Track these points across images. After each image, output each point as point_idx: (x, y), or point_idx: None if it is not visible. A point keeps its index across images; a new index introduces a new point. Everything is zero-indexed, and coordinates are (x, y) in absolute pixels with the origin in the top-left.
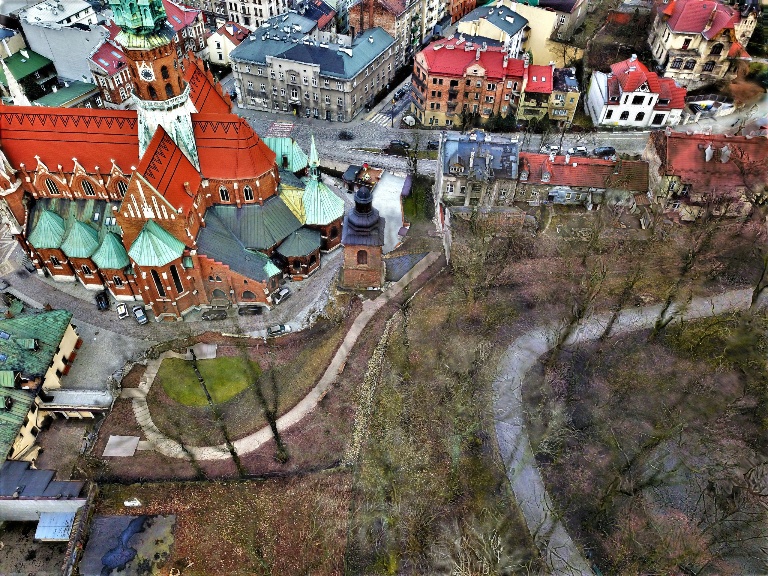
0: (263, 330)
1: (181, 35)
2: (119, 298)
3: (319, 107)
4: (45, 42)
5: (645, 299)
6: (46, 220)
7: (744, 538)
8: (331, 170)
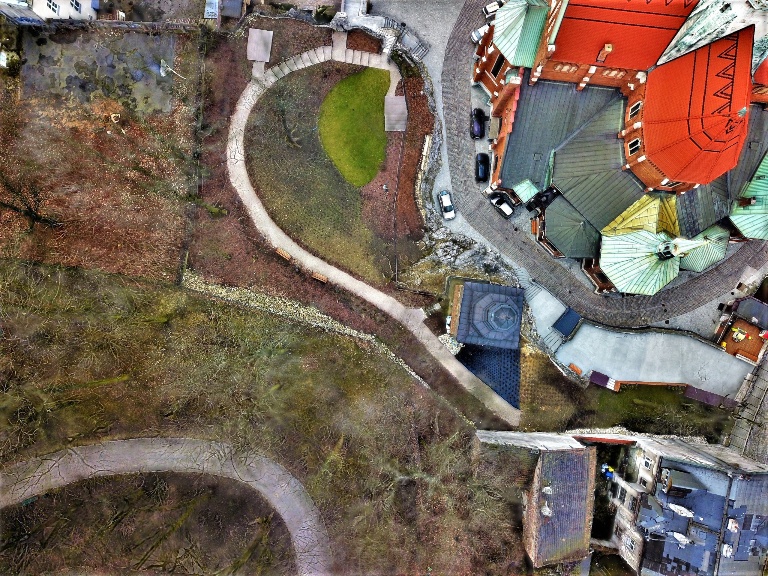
0: (451, 185)
1: None
2: None
3: None
4: None
5: None
6: None
7: None
8: None
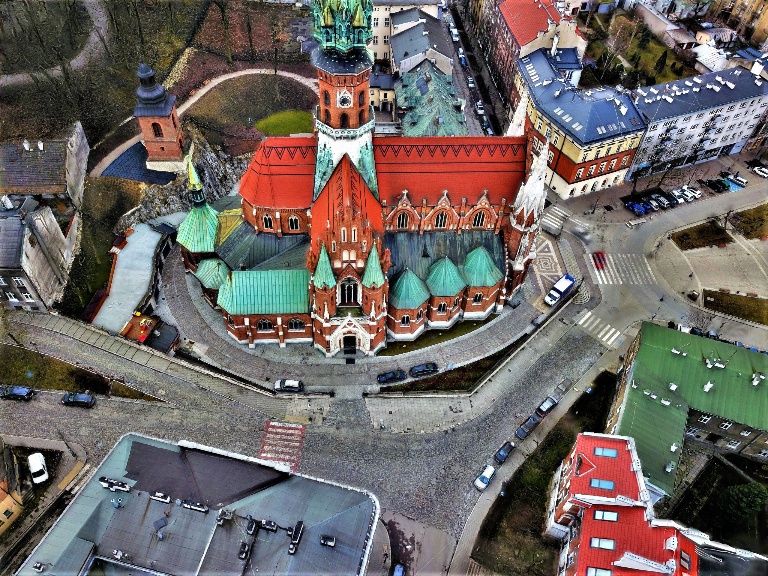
0: None
1: None
2: None
3: None
4: None
5: None
6: None
7: None
8: None
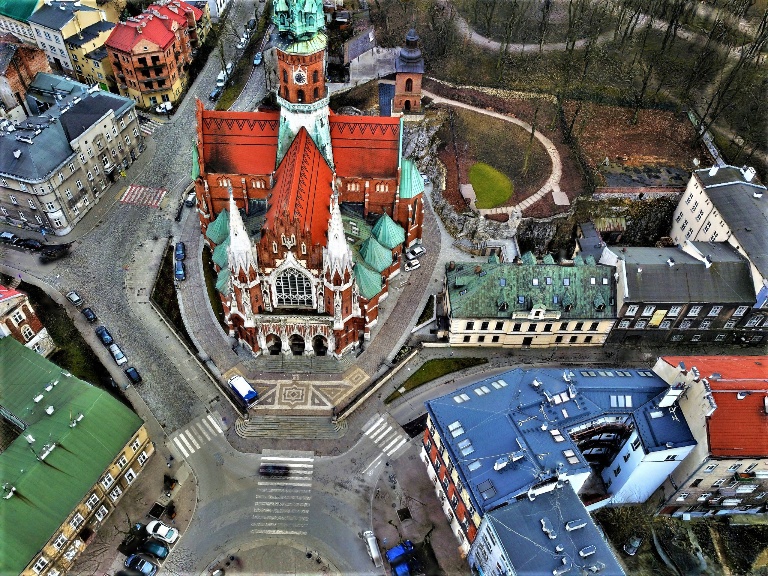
0: None
1: None
2: None
3: (125, 154)
4: None
5: (437, 8)
6: (363, 267)
7: (562, 7)
8: None
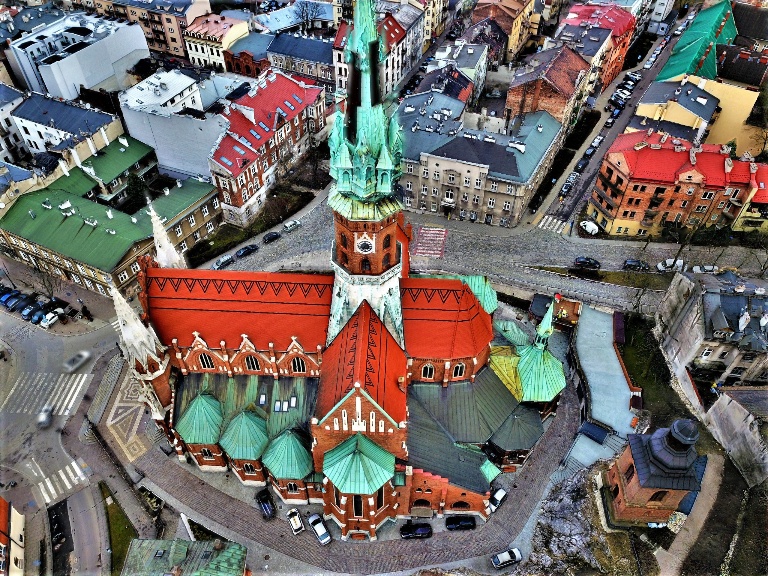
0: (484, 555)
1: (301, 116)
2: (288, 501)
3: (478, 210)
4: (148, 128)
5: None
6: (202, 408)
7: None
8: (507, 296)
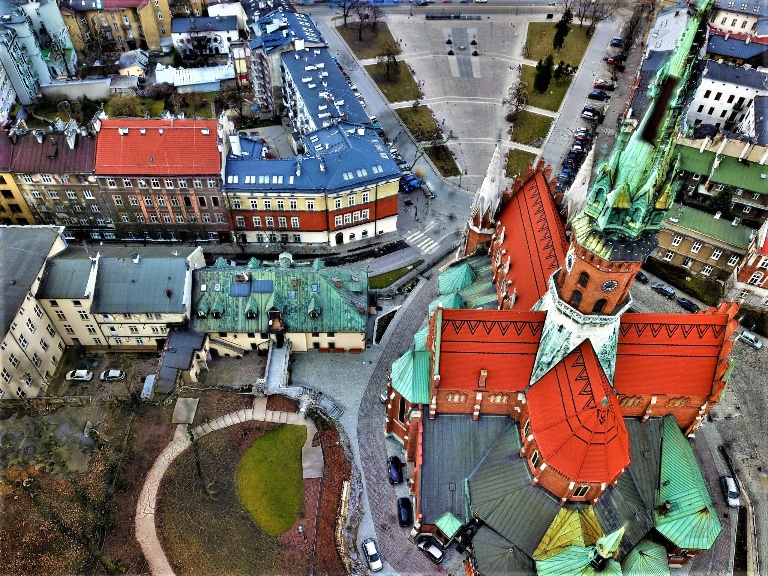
0: (375, 533)
1: None
2: None
3: None
4: None
5: None
6: (461, 270)
7: None
8: None
